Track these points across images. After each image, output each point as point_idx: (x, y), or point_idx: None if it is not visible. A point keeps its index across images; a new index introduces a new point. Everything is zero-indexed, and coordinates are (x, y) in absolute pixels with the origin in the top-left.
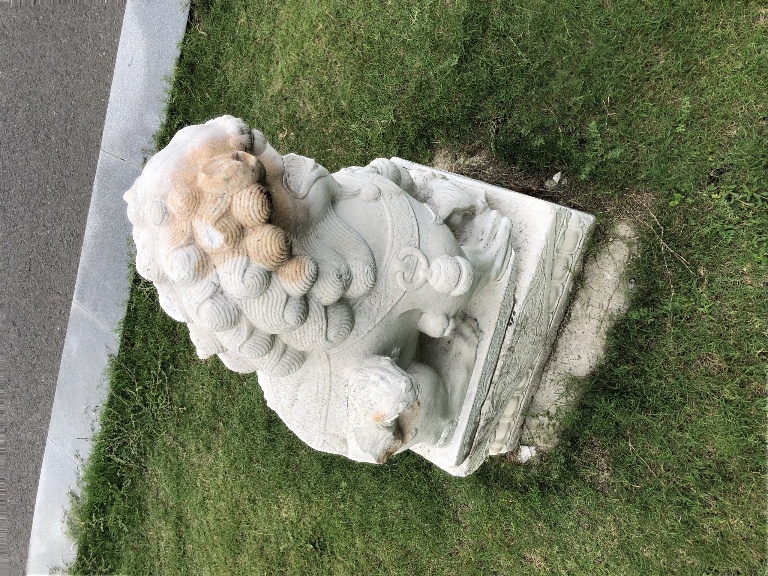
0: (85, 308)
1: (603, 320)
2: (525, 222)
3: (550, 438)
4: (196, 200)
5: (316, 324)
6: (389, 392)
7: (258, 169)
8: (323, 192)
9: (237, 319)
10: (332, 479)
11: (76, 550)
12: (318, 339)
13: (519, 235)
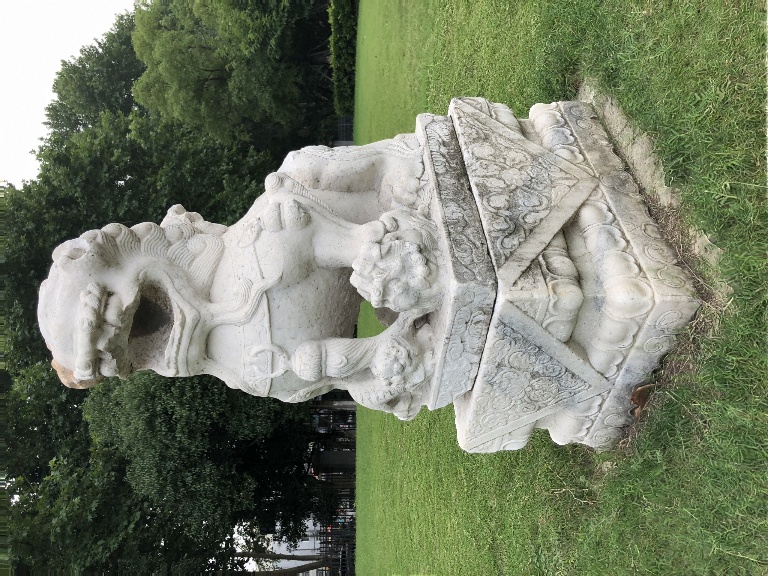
0: None
1: None
2: (460, 416)
3: None
4: None
5: None
6: None
7: None
8: None
9: None
10: (545, 5)
11: None
12: None
13: (458, 403)
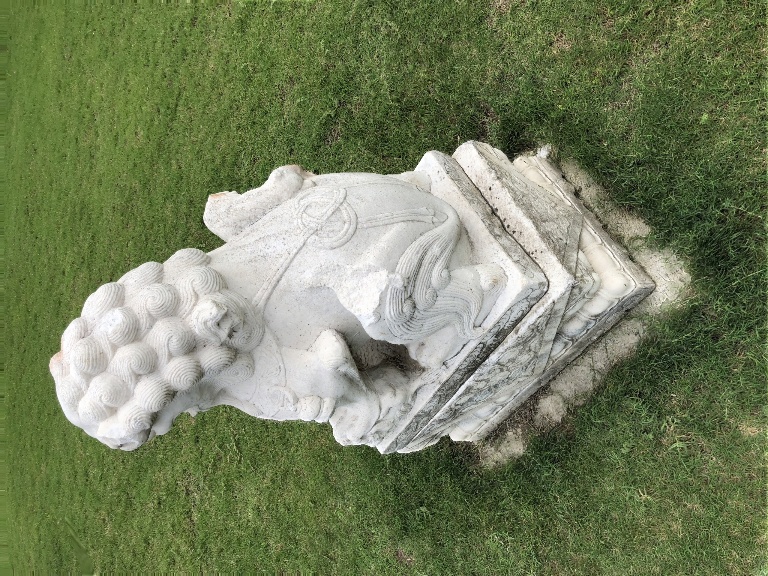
0: None
1: None
2: None
3: None
4: None
5: None
6: None
7: None
8: None
9: None
10: None
11: None
12: None
13: None
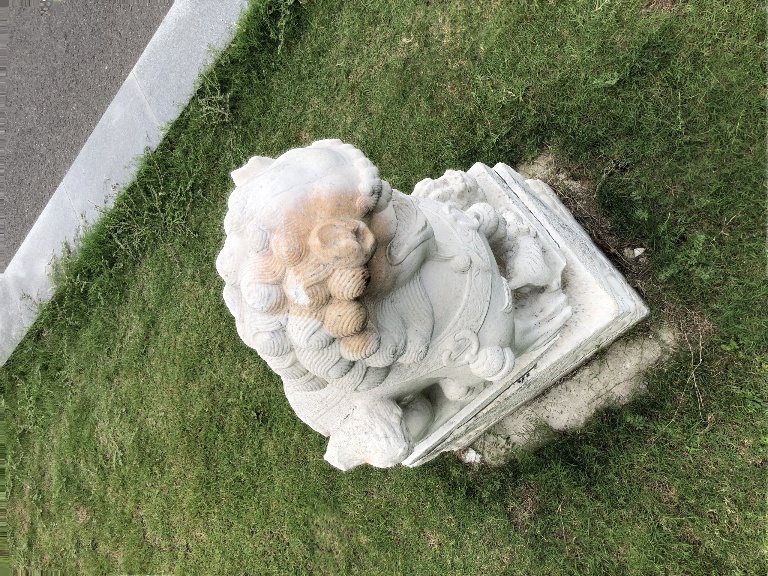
0: (141, 86)
1: (600, 397)
2: (585, 307)
3: (498, 458)
4: (300, 256)
5: (353, 378)
6: (386, 451)
7: (371, 253)
8: (419, 259)
9: (286, 353)
10: None
11: (52, 293)
12: (348, 387)
13: None
